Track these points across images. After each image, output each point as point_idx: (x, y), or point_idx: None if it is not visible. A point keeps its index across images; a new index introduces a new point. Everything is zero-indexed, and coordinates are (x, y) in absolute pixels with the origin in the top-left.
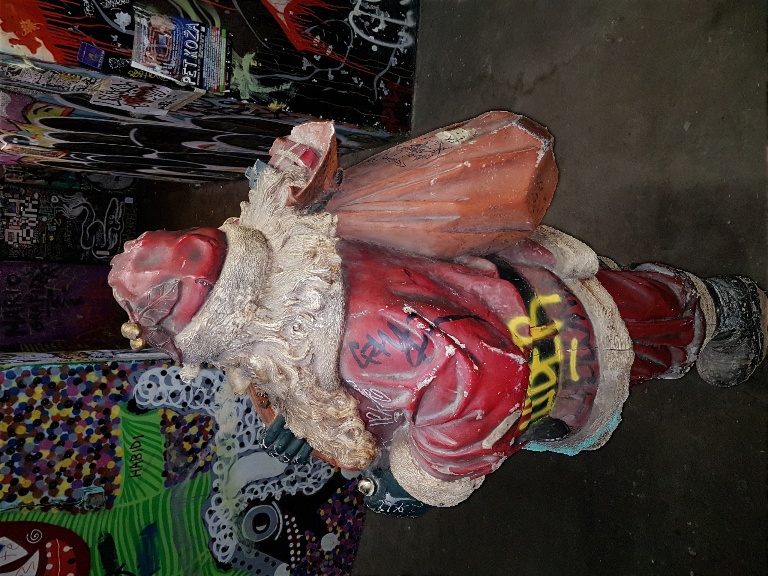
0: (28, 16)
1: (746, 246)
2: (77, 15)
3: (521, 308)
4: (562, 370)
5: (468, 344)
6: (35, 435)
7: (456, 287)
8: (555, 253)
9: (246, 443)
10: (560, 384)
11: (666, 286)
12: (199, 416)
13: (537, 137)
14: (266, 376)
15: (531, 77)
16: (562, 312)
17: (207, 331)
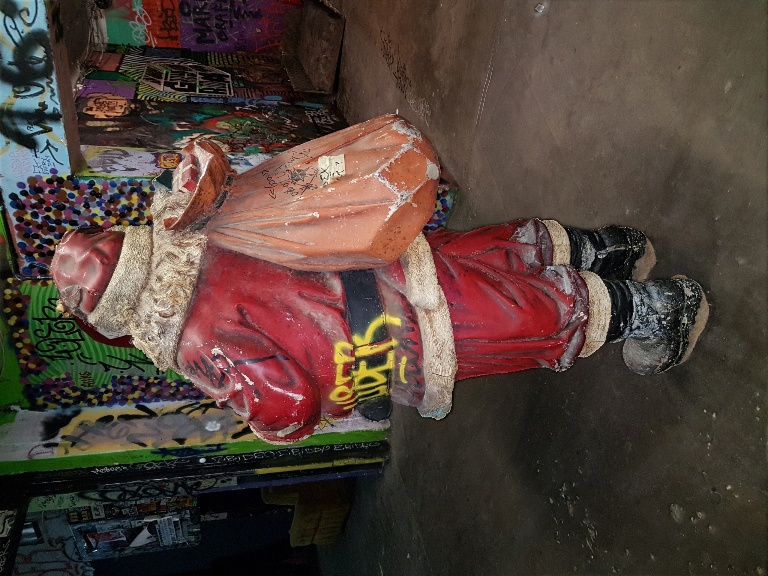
0: None
1: (719, 251)
2: None
3: (346, 337)
4: (394, 374)
5: (256, 382)
6: None
7: (296, 310)
8: (408, 284)
9: None
10: (393, 381)
11: (555, 304)
12: None
13: (396, 190)
14: None
15: None
16: (399, 334)
17: (101, 322)
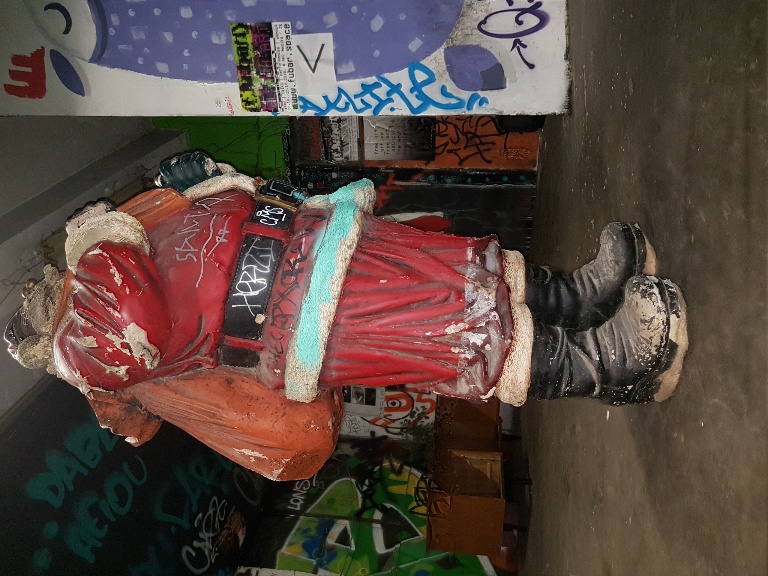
0: None
1: None
2: None
3: None
4: None
5: None
6: None
7: None
8: None
9: None
10: None
11: None
12: None
13: None
14: None
15: None
16: None
17: None
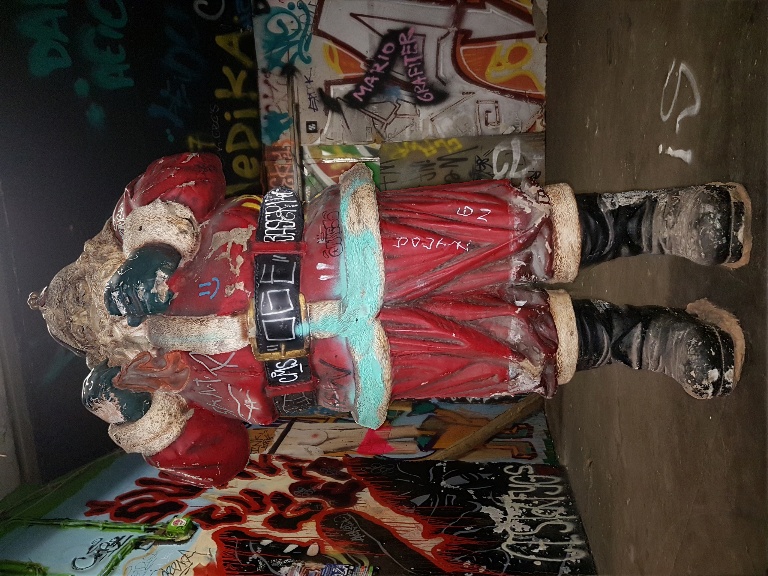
0: (215, 575)
1: None
2: (250, 571)
3: None
4: None
5: None
6: None
7: None
8: None
9: None
10: None
11: None
12: None
13: None
14: None
15: (617, 430)
16: None
17: None
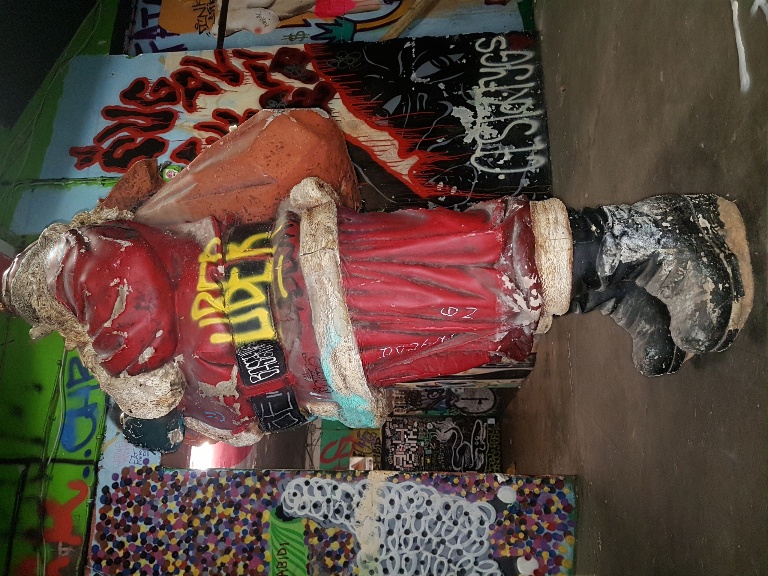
0: None
1: (719, 160)
2: None
3: (214, 232)
4: (274, 289)
5: (92, 239)
6: (205, 529)
7: (179, 232)
8: None
9: (390, 570)
10: (276, 305)
11: None
12: (340, 531)
13: (275, 110)
14: None
15: (592, 128)
16: None
17: None
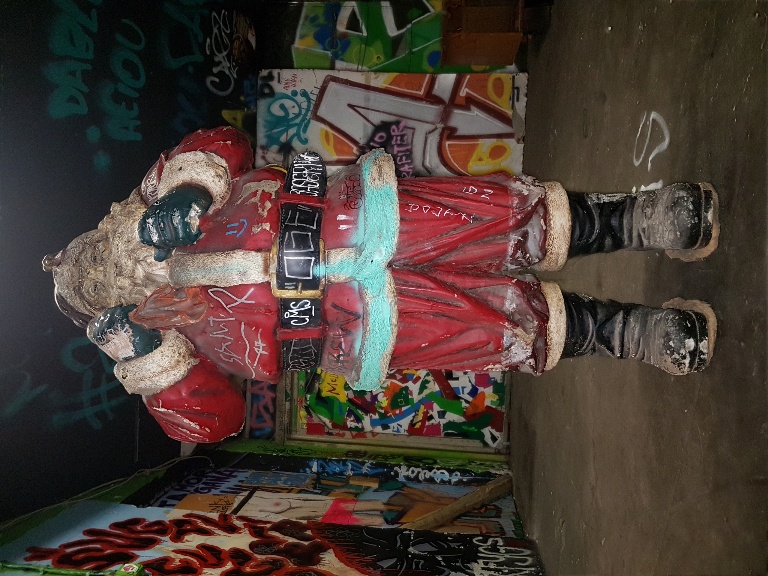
0: None
1: None
2: None
3: None
4: None
5: None
6: None
7: None
8: None
9: None
10: None
11: None
12: None
13: None
14: (107, 242)
15: (592, 472)
16: None
17: None
